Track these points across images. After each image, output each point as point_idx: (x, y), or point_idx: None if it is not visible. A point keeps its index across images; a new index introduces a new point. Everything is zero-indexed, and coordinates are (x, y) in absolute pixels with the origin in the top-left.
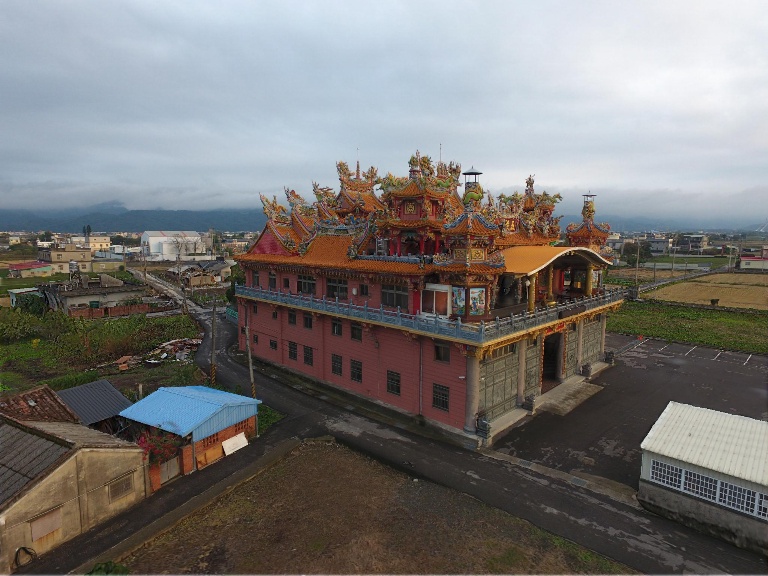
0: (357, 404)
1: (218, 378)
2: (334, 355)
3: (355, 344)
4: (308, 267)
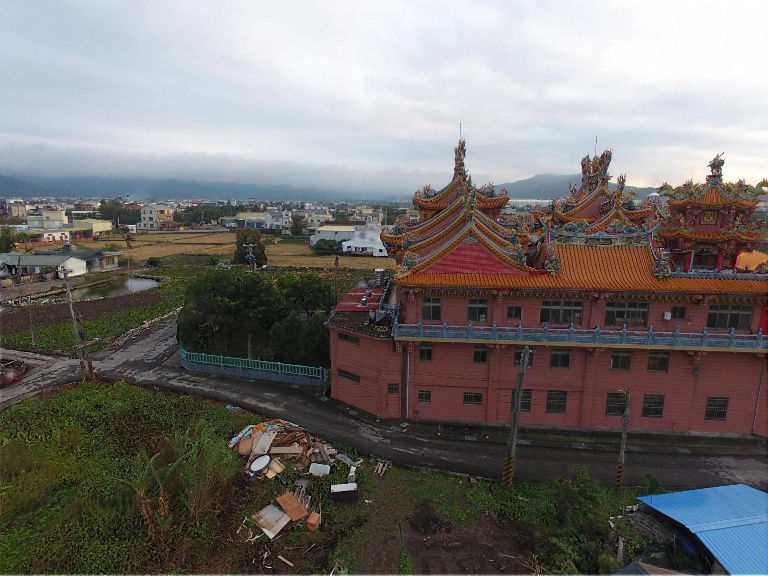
0: (677, 443)
1: (492, 473)
2: (613, 394)
3: (656, 376)
4: (593, 291)
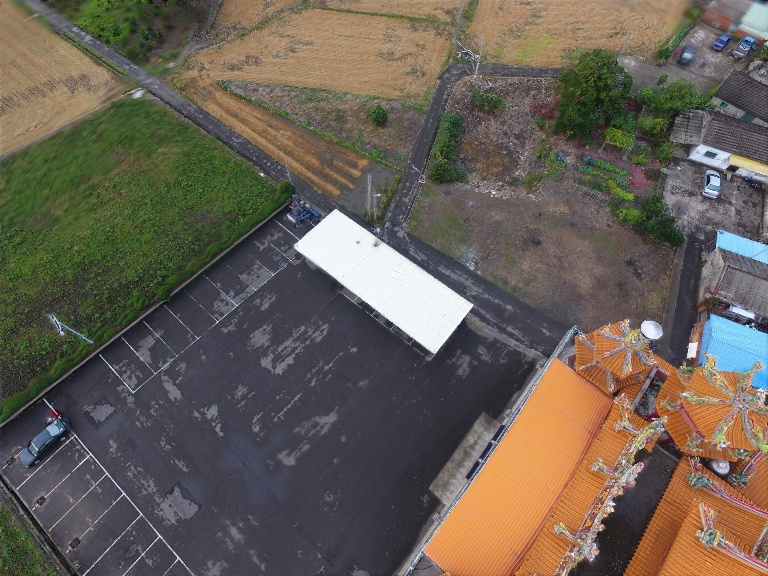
0: None
1: None
2: None
3: None
4: None
